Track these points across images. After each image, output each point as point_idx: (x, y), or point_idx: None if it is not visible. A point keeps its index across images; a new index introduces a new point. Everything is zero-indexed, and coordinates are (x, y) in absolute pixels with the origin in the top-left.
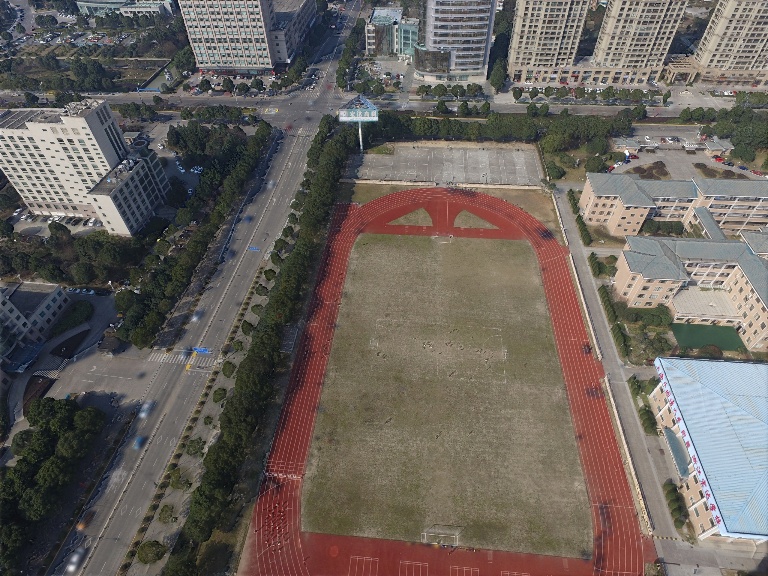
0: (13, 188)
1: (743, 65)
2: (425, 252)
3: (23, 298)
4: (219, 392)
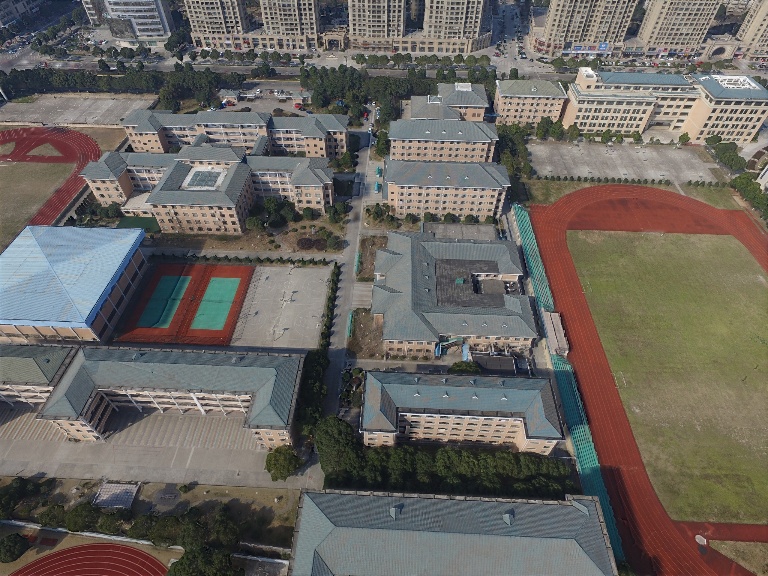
0: None
1: (379, 33)
2: None
3: None
4: None
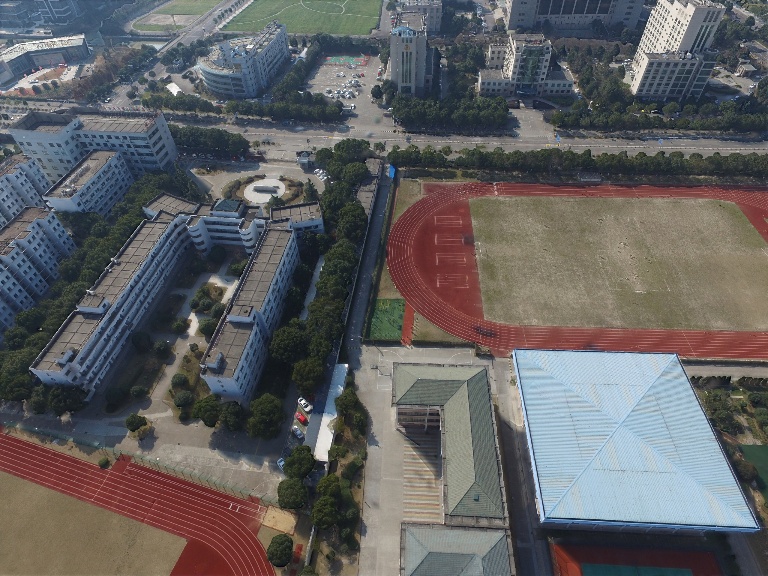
0: None
1: None
2: (741, 243)
3: (559, 74)
4: (534, 151)
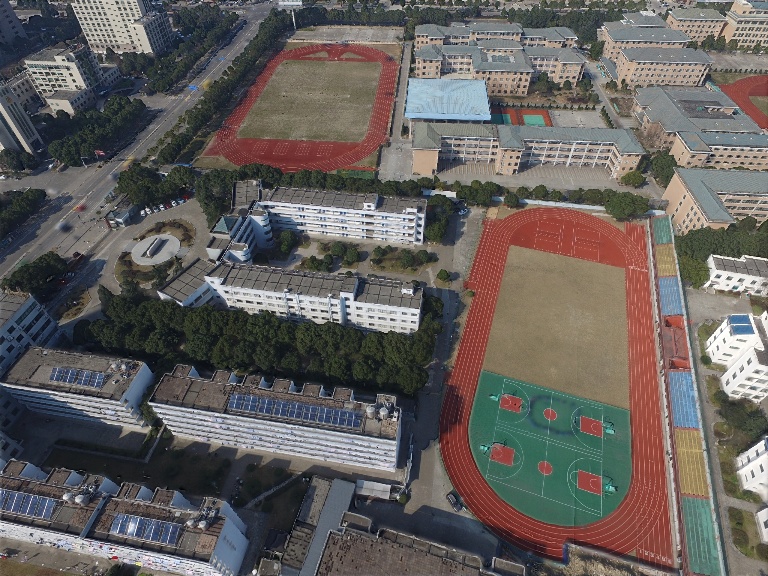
0: (81, 37)
1: None
2: (320, 66)
3: None
4: (201, 99)
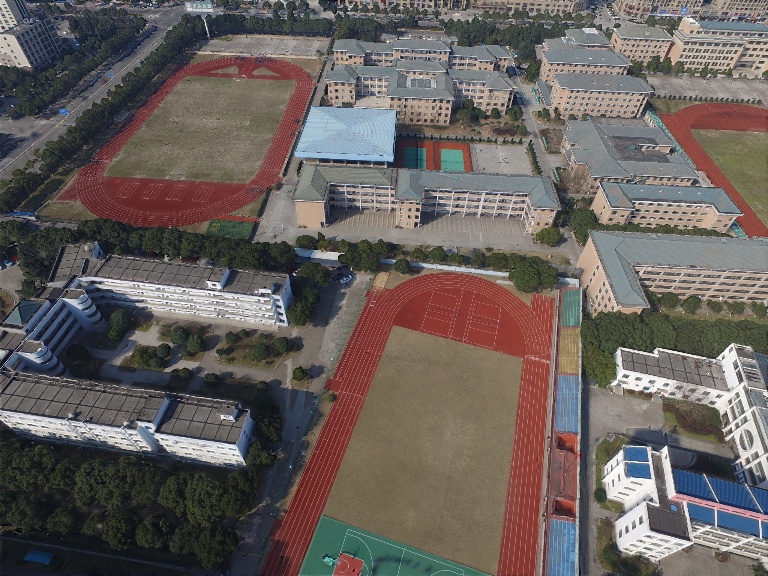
0: None
1: None
2: (226, 84)
3: None
4: (70, 127)
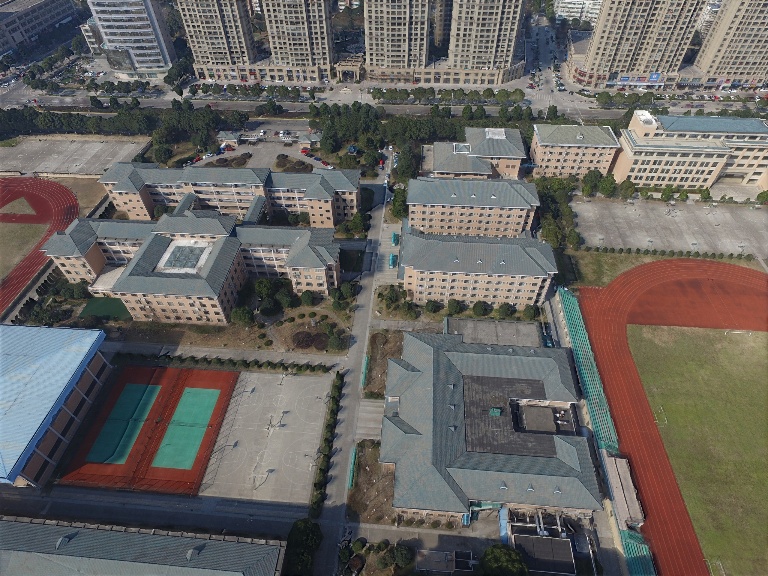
0: None
1: (399, 64)
2: None
3: None
4: None
